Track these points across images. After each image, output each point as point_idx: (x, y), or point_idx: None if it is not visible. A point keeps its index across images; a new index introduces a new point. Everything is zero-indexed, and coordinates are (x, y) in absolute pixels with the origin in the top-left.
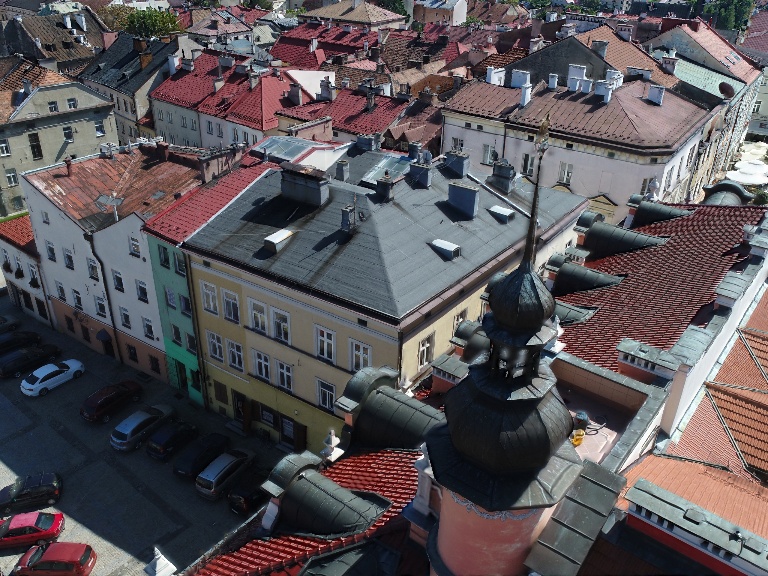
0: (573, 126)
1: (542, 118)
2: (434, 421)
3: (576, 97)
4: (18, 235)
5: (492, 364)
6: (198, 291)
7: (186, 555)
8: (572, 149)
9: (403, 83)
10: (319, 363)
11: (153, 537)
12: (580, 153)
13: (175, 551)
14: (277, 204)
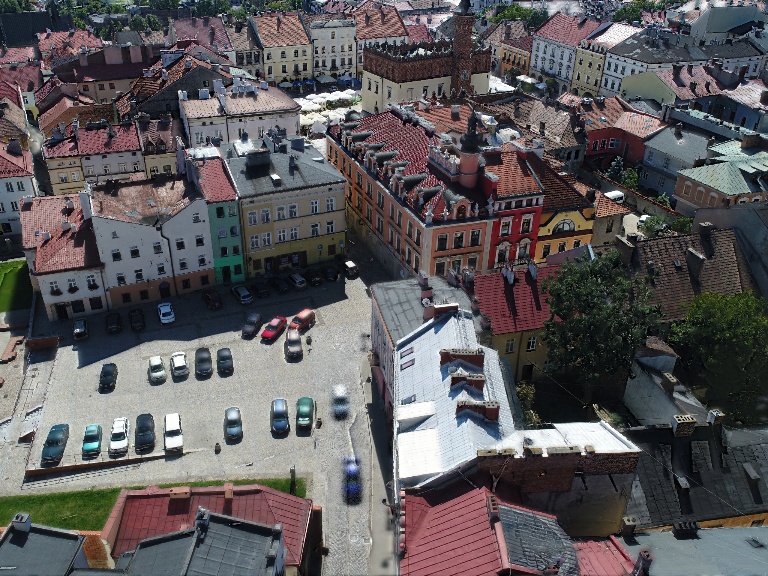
0: (258, 109)
1: (240, 109)
2: (419, 175)
3: (241, 95)
4: (69, 264)
5: (470, 132)
6: (246, 218)
7: (325, 299)
8: (263, 119)
9: (15, 121)
10: (313, 216)
11: (308, 304)
12: (267, 120)
13: (321, 301)
14: (252, 170)
